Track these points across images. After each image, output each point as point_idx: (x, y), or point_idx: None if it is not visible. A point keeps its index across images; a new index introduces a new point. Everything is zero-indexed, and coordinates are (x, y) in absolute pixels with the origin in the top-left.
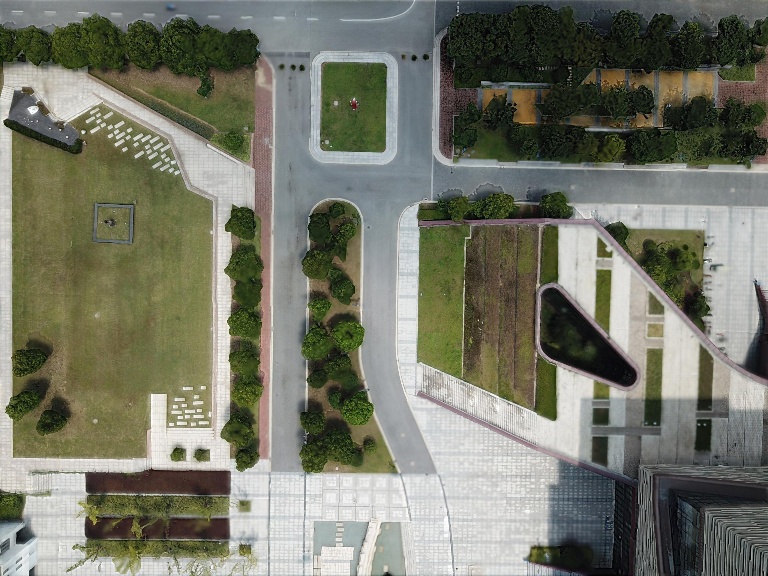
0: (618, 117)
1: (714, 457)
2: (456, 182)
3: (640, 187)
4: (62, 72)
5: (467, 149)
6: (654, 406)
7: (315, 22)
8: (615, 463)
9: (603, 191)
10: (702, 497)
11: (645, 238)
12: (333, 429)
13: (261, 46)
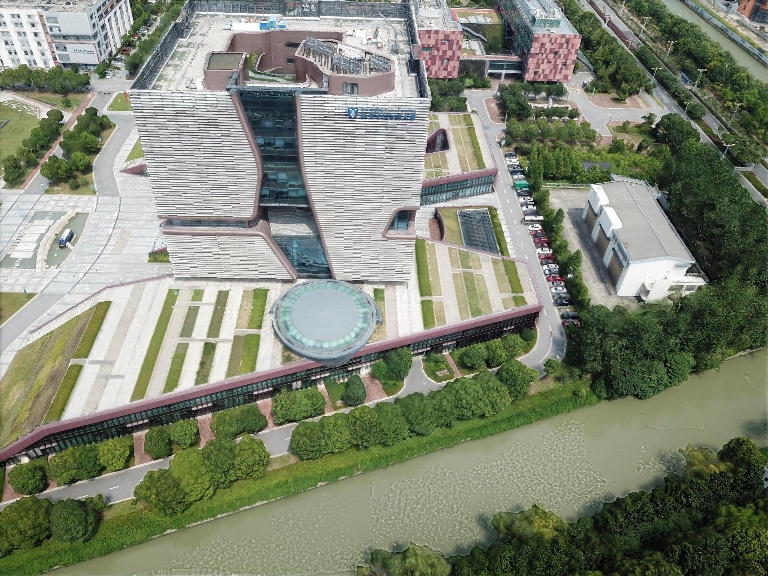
0: None
1: None
2: None
3: None
4: (1, 93)
5: None
6: None
7: (120, 86)
8: None
9: None
10: None
11: None
12: (67, 180)
13: (94, 90)
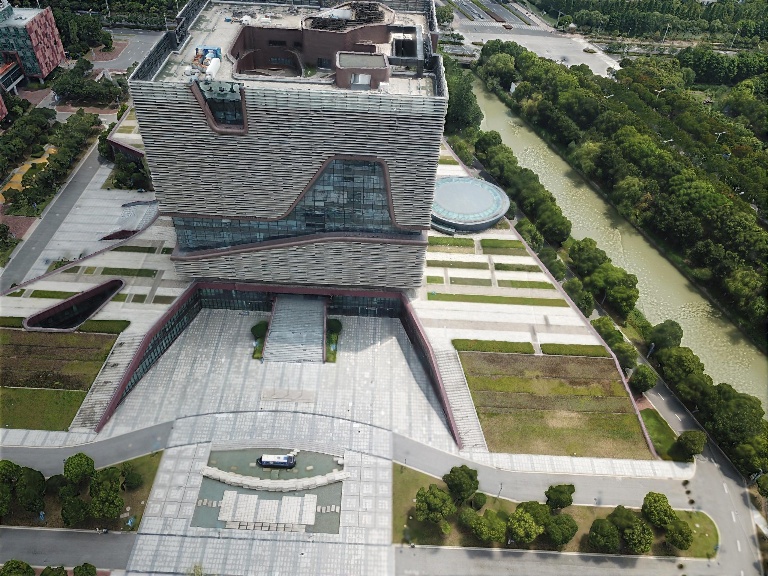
0: None
1: None
2: None
3: None
4: None
5: None
6: (142, 272)
7: None
8: (176, 293)
9: None
10: None
11: None
12: None
13: None
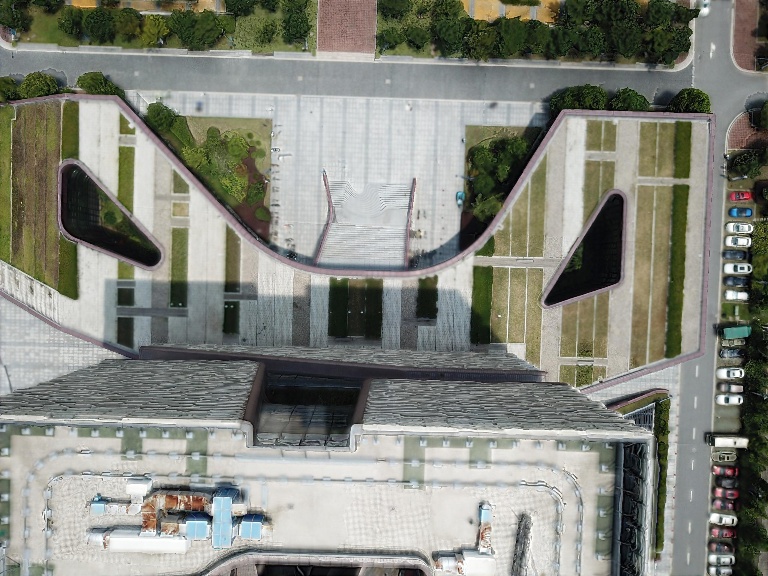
0: (180, 2)
1: (242, 340)
2: (18, 67)
3: (206, 74)
4: None
5: (28, 33)
6: (179, 287)
7: None
8: (142, 345)
9: (168, 78)
10: None
11: (210, 126)
12: None
13: None
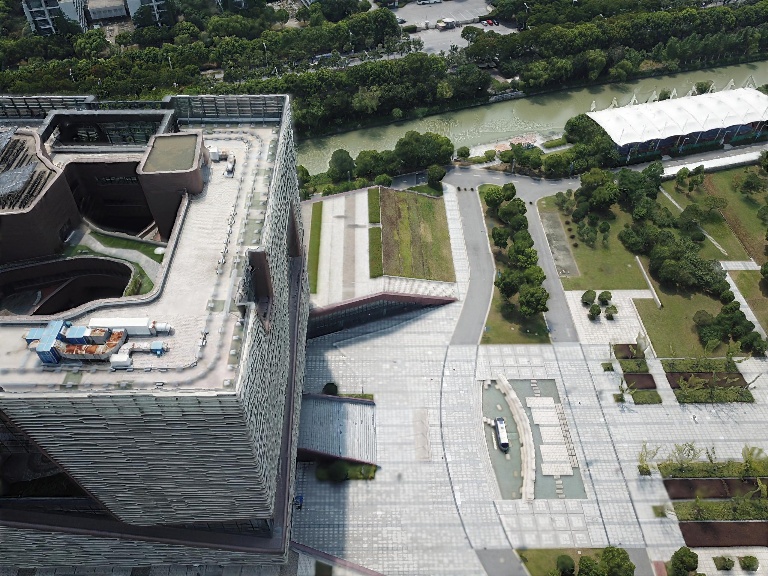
0: None
1: (201, 575)
2: None
3: None
4: None
5: None
6: None
7: None
8: (307, 566)
9: None
10: (246, 530)
11: None
12: None
13: None
